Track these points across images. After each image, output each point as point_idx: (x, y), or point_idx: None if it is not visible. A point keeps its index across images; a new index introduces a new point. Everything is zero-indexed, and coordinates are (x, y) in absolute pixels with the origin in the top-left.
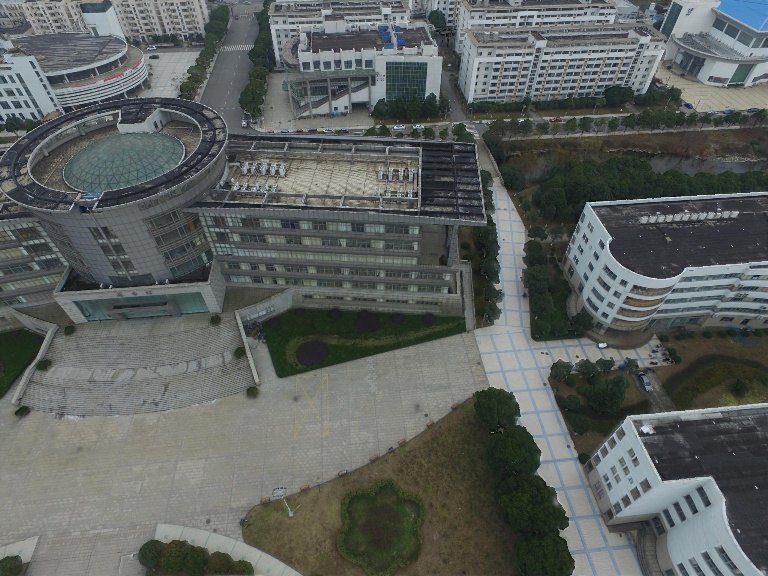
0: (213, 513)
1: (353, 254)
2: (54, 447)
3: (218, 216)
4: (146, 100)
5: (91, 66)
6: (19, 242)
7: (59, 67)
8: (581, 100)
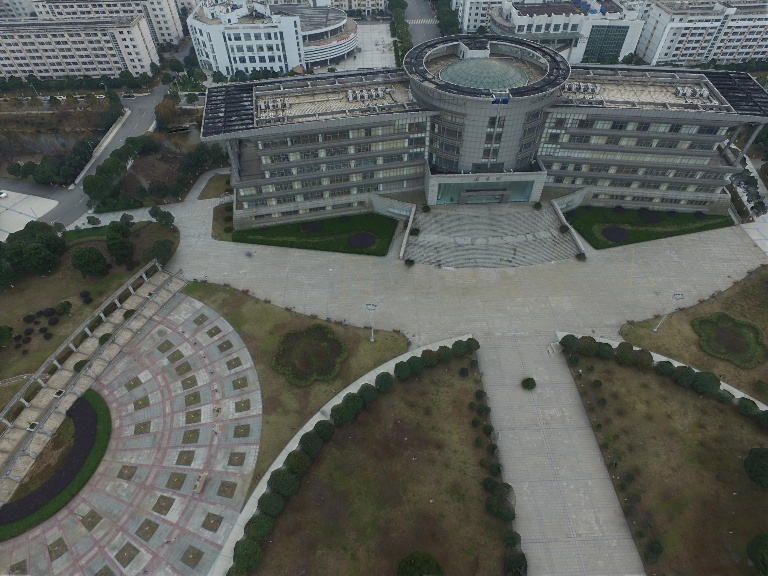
0: (594, 327)
1: (658, 154)
2: (447, 285)
3: (563, 118)
4: (472, 36)
5: (328, 29)
6: (410, 134)
7: (302, 29)
8: (757, 63)
